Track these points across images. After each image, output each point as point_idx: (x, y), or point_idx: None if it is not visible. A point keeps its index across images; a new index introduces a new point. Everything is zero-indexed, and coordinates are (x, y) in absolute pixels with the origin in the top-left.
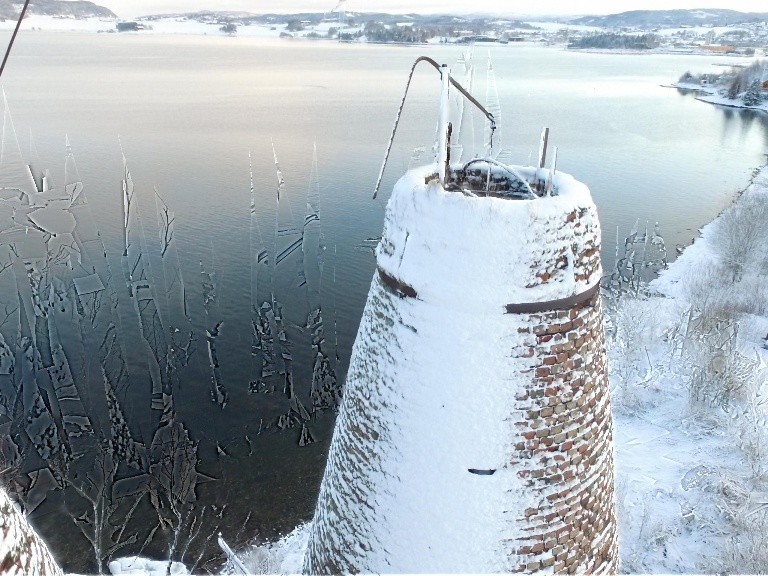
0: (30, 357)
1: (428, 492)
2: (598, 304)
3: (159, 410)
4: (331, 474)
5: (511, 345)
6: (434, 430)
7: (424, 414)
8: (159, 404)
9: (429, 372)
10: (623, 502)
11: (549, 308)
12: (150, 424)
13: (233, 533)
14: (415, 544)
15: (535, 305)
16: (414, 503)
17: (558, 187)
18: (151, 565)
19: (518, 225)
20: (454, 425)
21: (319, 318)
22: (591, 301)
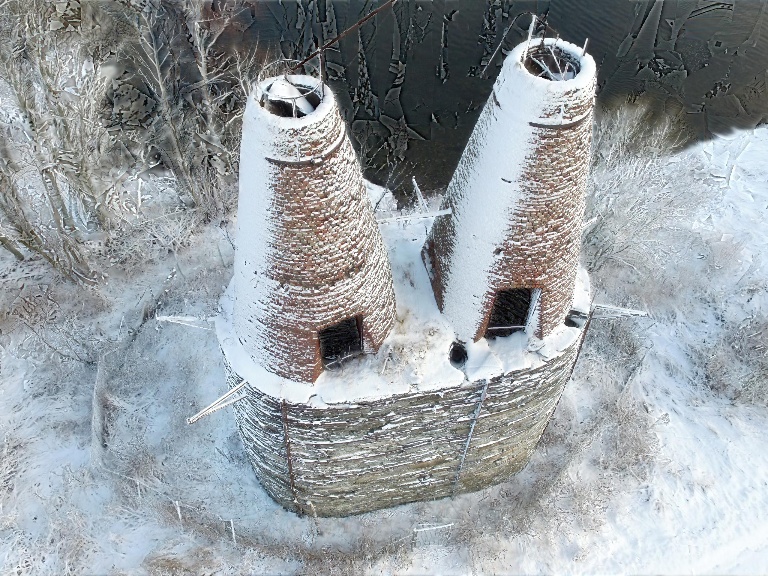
0: (311, 10)
1: (486, 182)
2: (578, 129)
3: (394, 73)
4: (459, 164)
5: (528, 138)
6: (493, 160)
7: (491, 153)
8: (395, 68)
9: (497, 138)
10: (737, 254)
11: (547, 127)
12: (386, 83)
13: (429, 182)
14: (478, 199)
15: (541, 125)
16: (481, 185)
17: (579, 72)
18: (371, 185)
19: (541, 93)
20: (500, 161)
21: (545, 21)
22: (573, 127)
